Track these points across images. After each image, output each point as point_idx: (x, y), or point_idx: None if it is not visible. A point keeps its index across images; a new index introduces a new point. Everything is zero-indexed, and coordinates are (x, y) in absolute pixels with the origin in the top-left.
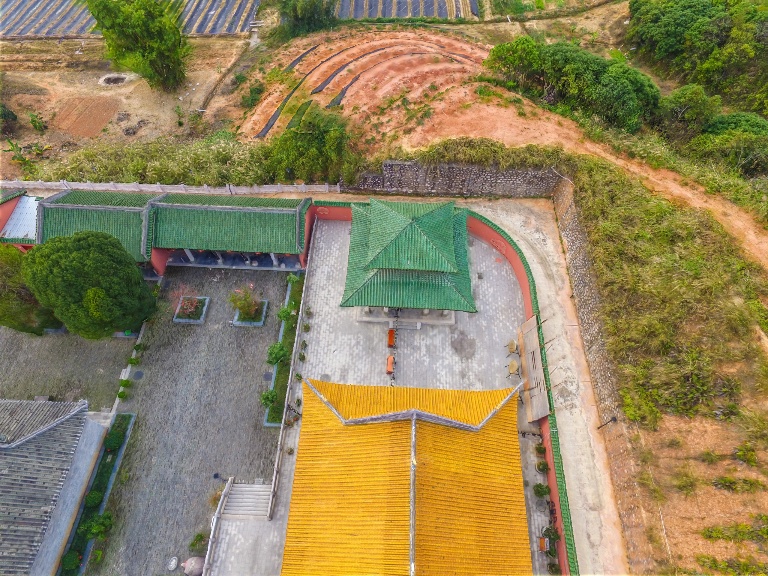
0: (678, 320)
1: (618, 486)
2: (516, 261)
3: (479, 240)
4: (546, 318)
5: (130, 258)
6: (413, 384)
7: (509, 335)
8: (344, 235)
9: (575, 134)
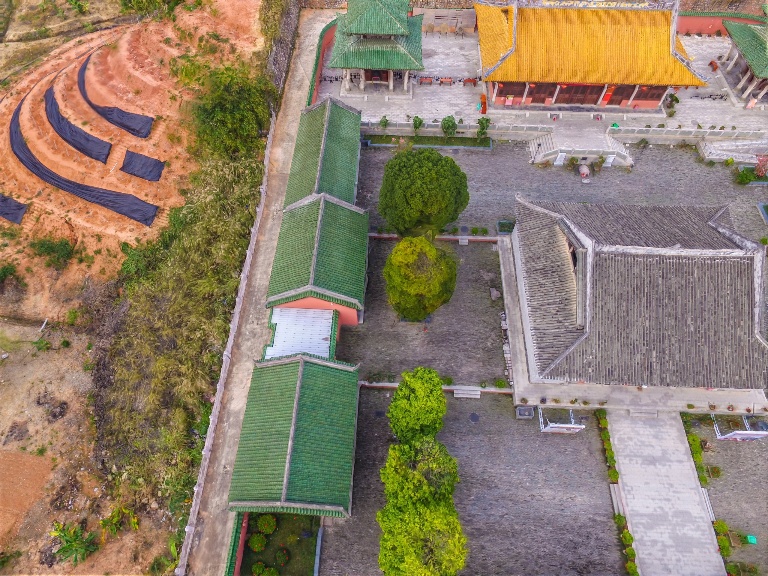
0: None
1: None
2: None
3: None
4: None
5: None
6: (457, 75)
7: None
8: None
9: None
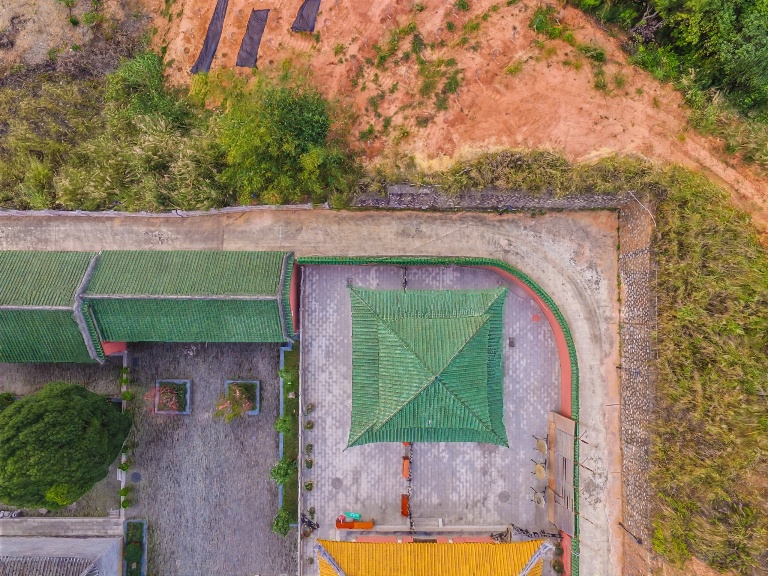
0: (743, 470)
1: None
2: (559, 332)
3: (514, 294)
4: (584, 397)
5: (81, 409)
6: (431, 485)
7: (539, 421)
8: (341, 289)
9: (675, 122)
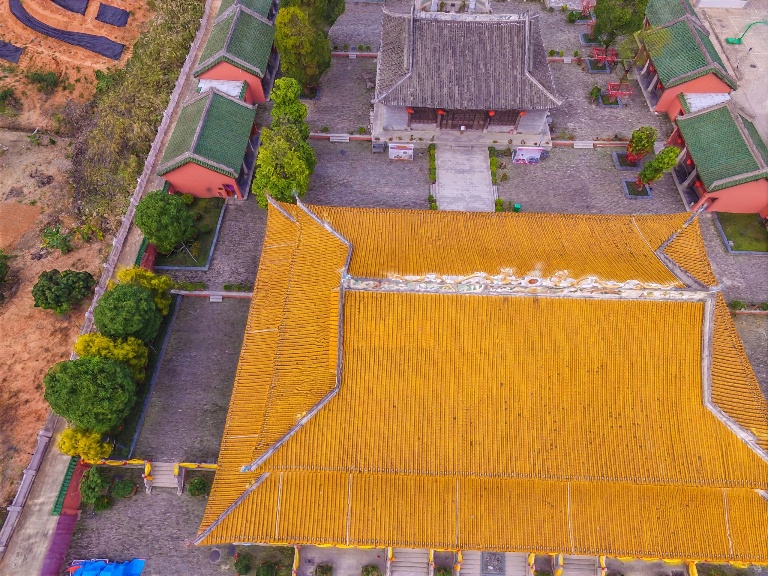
0: None
1: None
2: None
3: None
4: None
5: None
6: None
7: None
8: None
9: None
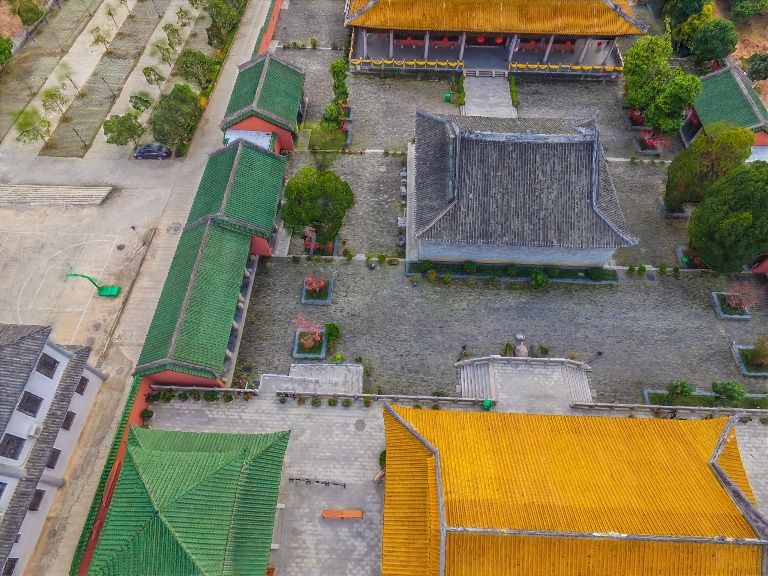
0: None
1: None
2: None
3: None
4: None
5: None
6: None
7: None
8: None
9: None
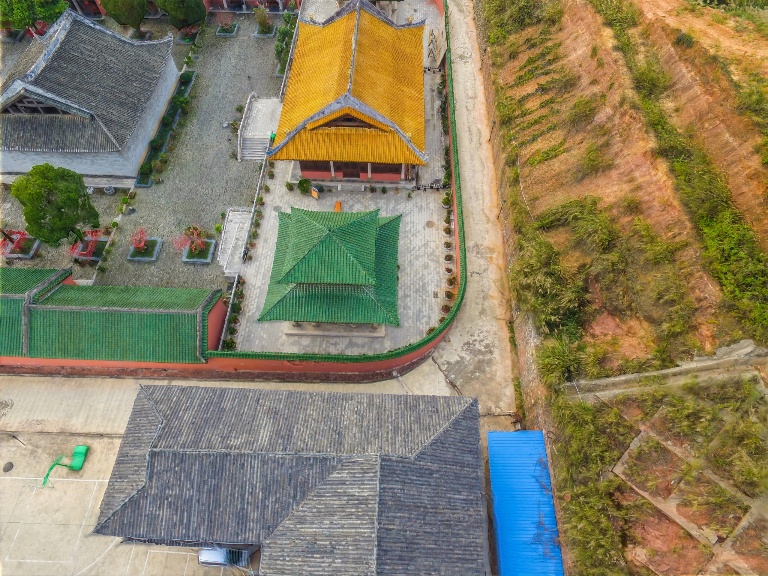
0: None
1: (486, 85)
2: None
3: None
4: (456, 28)
5: None
6: None
7: None
8: None
9: None
